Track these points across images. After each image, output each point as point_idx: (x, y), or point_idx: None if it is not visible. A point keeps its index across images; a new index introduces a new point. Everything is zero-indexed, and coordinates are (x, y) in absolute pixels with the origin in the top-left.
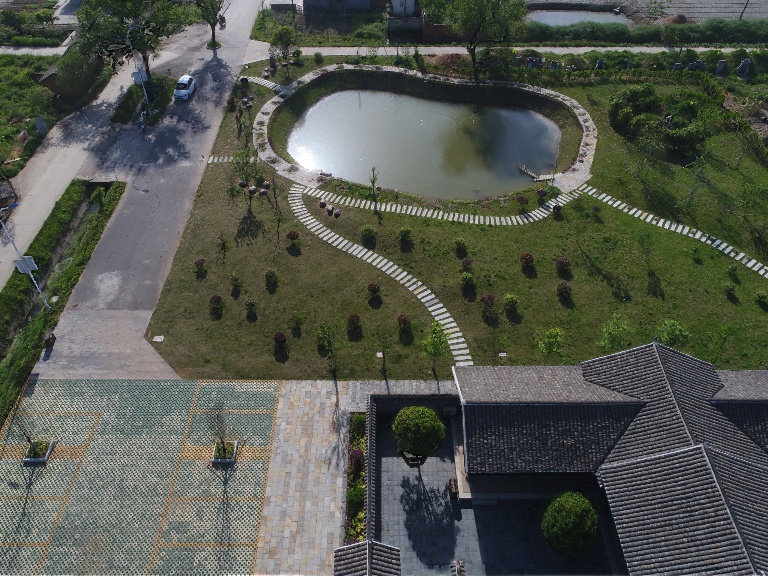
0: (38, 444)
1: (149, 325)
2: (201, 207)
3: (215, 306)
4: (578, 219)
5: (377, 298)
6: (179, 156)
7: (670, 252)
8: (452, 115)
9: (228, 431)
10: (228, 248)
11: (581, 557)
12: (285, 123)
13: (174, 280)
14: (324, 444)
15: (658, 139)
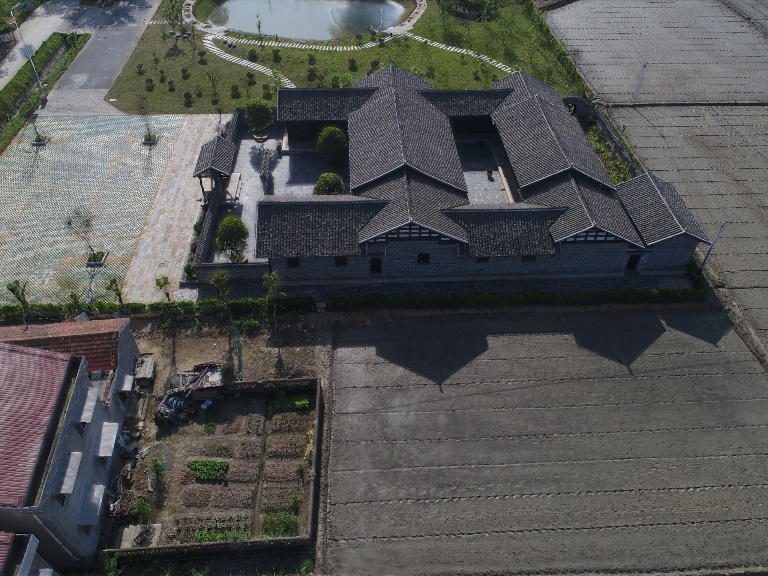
0: (40, 136)
1: (107, 95)
2: (143, 45)
3: (149, 86)
4: (394, 46)
5: (253, 82)
6: (128, 21)
7: (447, 59)
8: (331, 4)
9: (153, 133)
10: (159, 61)
11: (343, 169)
12: (207, 6)
13: (123, 76)
14: (209, 136)
15: (463, 6)
